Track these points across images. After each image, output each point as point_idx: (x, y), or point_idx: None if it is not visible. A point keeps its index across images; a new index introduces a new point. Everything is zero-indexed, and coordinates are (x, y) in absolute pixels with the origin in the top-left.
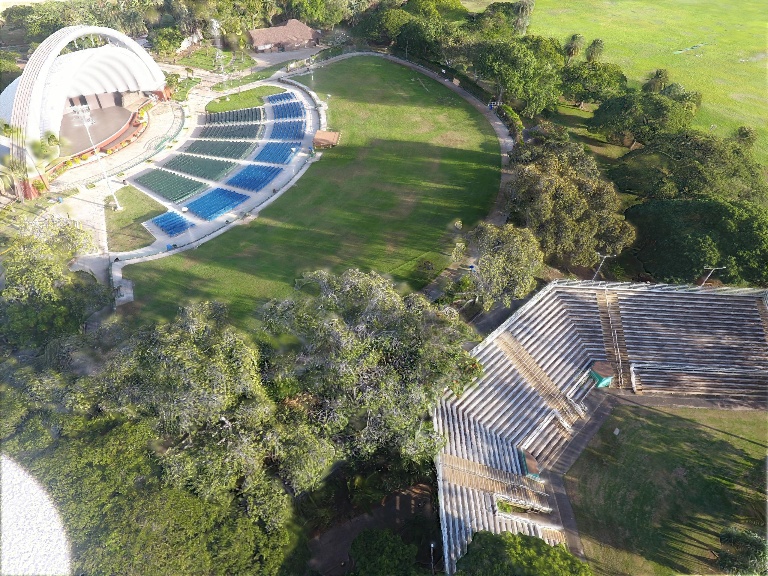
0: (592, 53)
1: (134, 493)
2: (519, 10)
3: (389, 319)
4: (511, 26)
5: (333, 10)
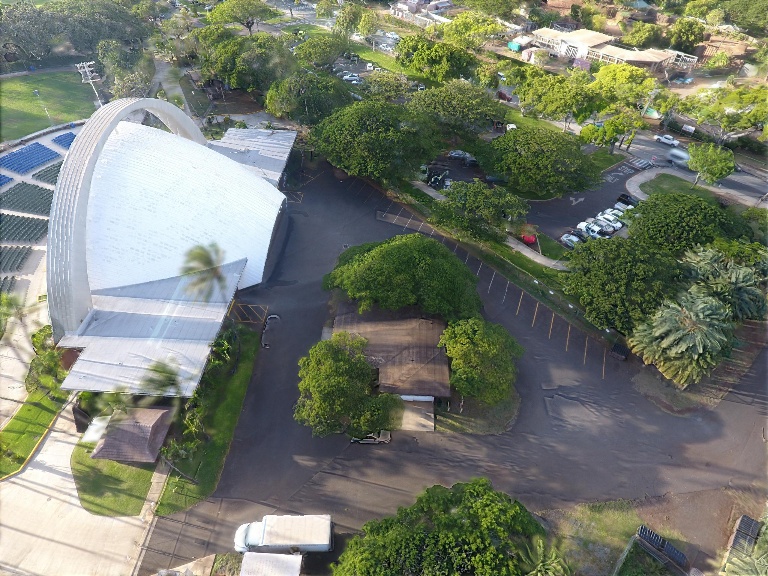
0: None
1: None
2: None
3: None
4: None
5: None
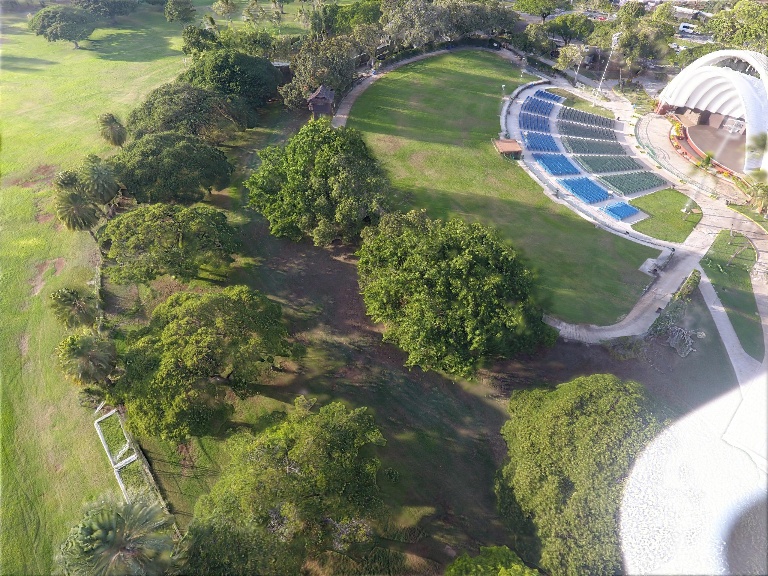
0: None
1: None
2: None
3: None
4: None
5: None
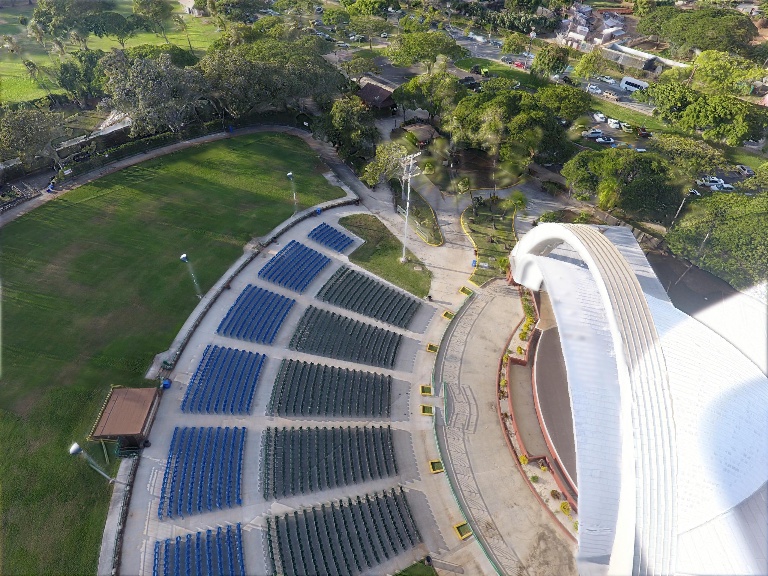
0: None
1: None
2: None
3: None
4: None
5: None
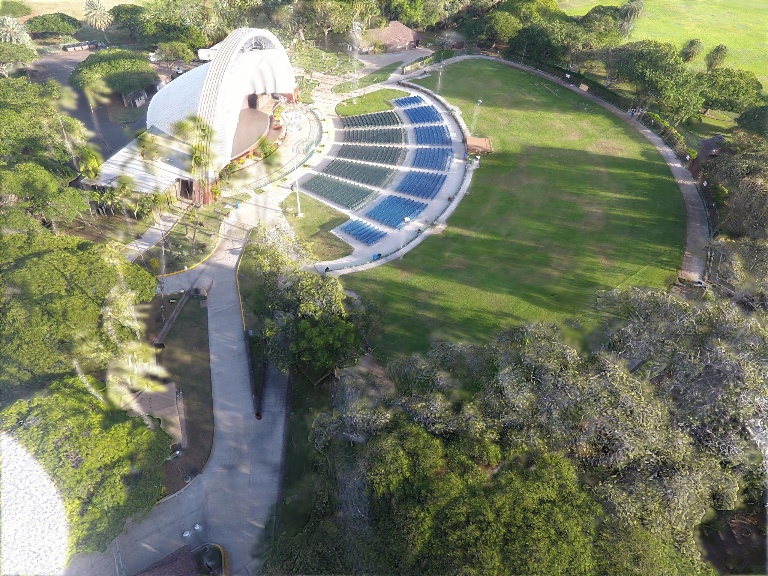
0: (715, 59)
1: (601, 532)
2: (627, 14)
3: (765, 347)
4: (616, 30)
5: (430, 11)
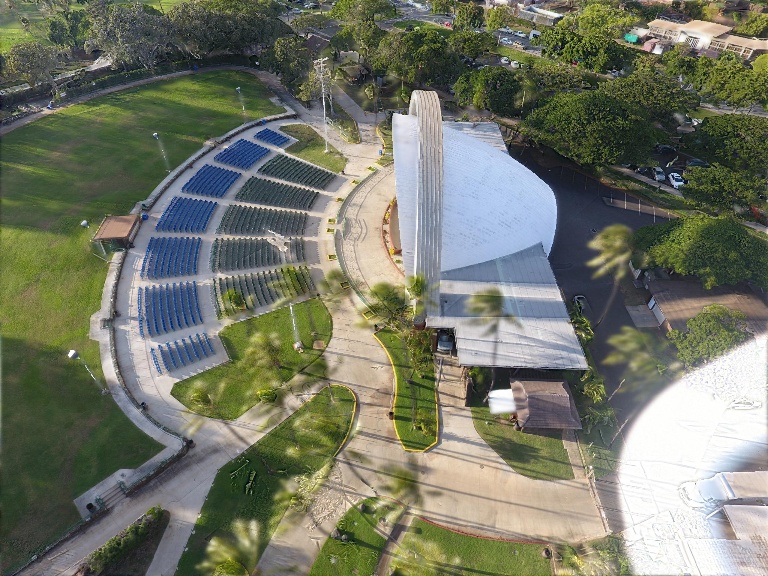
0: None
1: None
2: None
3: None
4: None
5: None
